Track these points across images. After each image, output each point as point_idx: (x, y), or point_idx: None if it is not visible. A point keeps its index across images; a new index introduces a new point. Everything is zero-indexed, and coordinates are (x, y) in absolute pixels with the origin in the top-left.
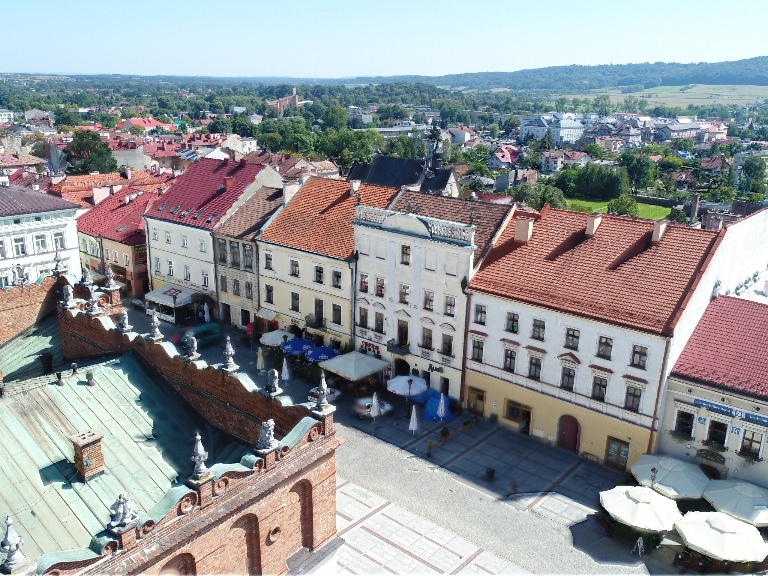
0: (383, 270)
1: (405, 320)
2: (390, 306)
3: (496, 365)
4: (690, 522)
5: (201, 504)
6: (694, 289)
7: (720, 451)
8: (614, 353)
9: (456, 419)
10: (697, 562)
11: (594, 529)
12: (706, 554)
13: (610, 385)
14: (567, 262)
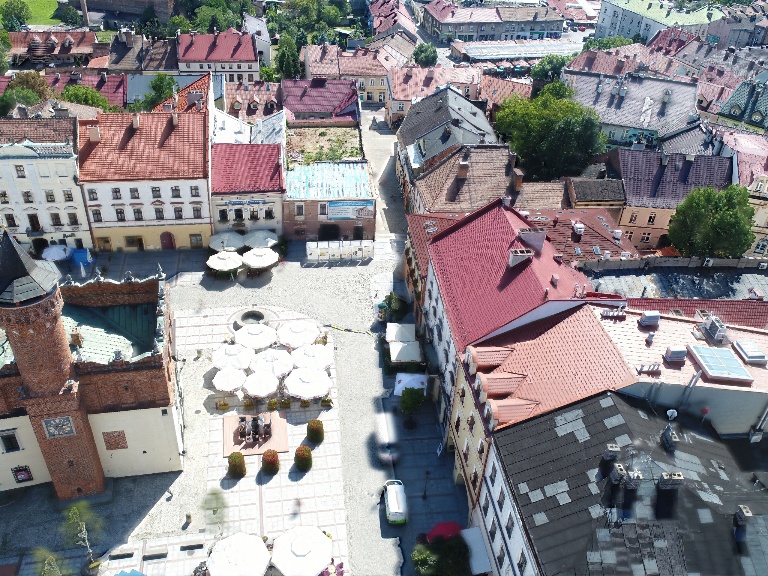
0: (3, 185)
1: (34, 213)
2: (18, 207)
3: (112, 220)
4: (248, 258)
5: (164, 320)
6: (208, 149)
7: (243, 221)
8: (182, 193)
9: (98, 260)
10: (256, 272)
11: (209, 280)
12: (260, 267)
13: (184, 210)
14: (133, 149)
